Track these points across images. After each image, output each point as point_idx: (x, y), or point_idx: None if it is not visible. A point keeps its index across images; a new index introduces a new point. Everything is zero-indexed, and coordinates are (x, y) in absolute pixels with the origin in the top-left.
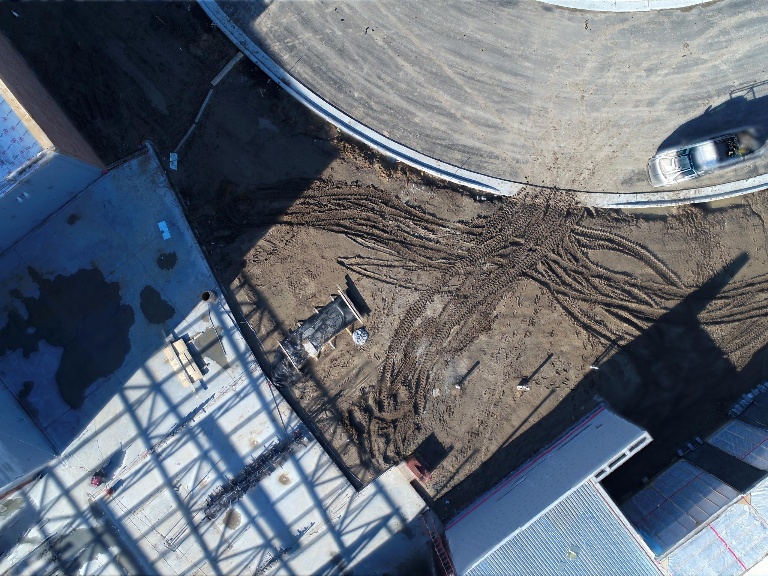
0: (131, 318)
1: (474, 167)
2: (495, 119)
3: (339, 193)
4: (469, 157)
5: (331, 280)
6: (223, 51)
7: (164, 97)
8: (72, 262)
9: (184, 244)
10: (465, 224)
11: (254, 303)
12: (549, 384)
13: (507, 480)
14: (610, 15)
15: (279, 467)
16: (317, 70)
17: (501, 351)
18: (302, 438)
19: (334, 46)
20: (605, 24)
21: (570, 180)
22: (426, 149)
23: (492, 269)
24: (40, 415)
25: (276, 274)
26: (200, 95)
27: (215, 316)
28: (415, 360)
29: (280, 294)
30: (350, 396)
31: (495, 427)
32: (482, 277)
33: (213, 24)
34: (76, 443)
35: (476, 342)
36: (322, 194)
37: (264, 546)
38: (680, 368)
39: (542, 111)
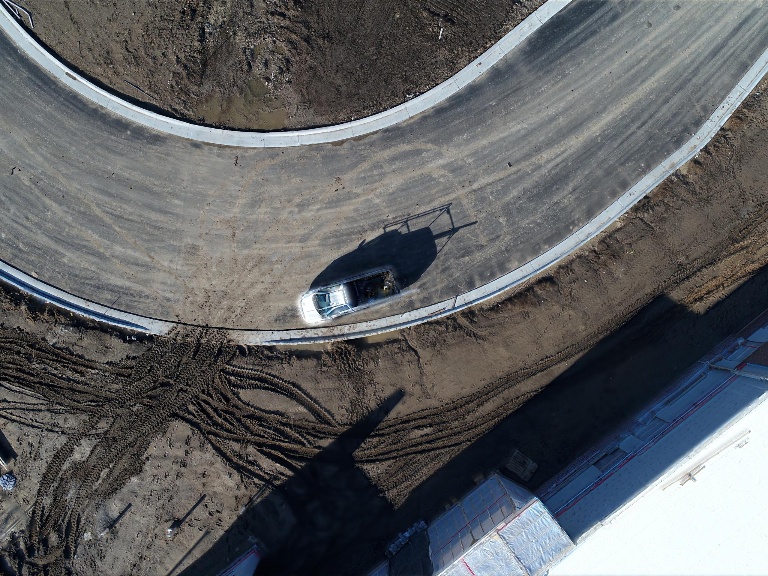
0: None
1: (124, 306)
2: (145, 258)
3: None
4: (119, 296)
5: None
6: None
7: None
8: None
9: None
10: (113, 365)
11: None
12: (202, 526)
13: None
14: (260, 151)
15: None
16: None
17: (153, 493)
18: None
19: None
20: (255, 160)
21: (222, 318)
22: (75, 289)
23: (142, 410)
24: None
25: None
26: None
27: None
28: (65, 504)
29: None
30: None
31: (148, 570)
32: (131, 419)
33: None
34: None
35: (128, 484)
36: None
37: None
38: (336, 507)
39: (193, 249)
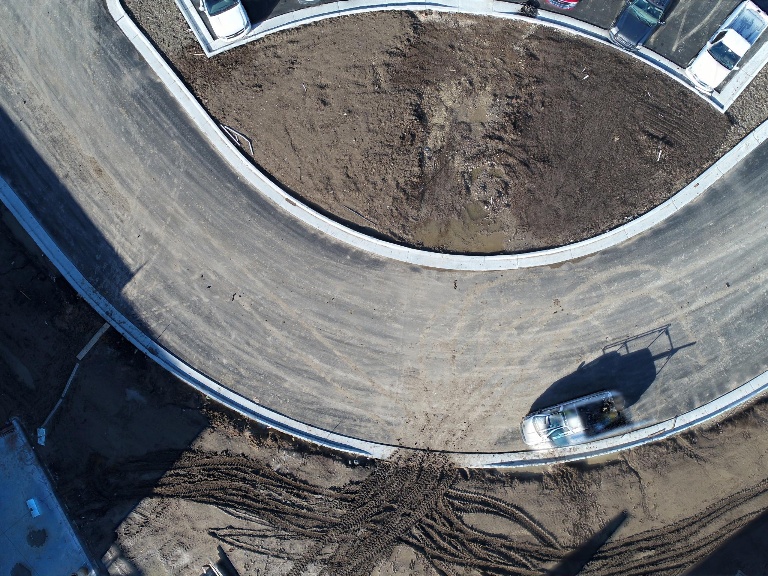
0: None
1: (346, 431)
2: (366, 382)
3: (209, 463)
4: (340, 421)
5: (203, 551)
6: (89, 324)
7: (30, 372)
8: None
9: (53, 521)
10: (337, 491)
11: (126, 575)
12: None
13: None
14: (479, 274)
15: None
16: (185, 338)
17: None
18: None
19: (201, 313)
20: (474, 283)
21: (443, 441)
22: (297, 414)
23: (366, 535)
24: None
25: (148, 546)
26: (66, 369)
27: None
28: None
29: (152, 566)
30: None
31: None
32: (356, 544)
33: (79, 295)
34: None
35: None
36: (192, 464)
37: None
38: None
39: (413, 372)
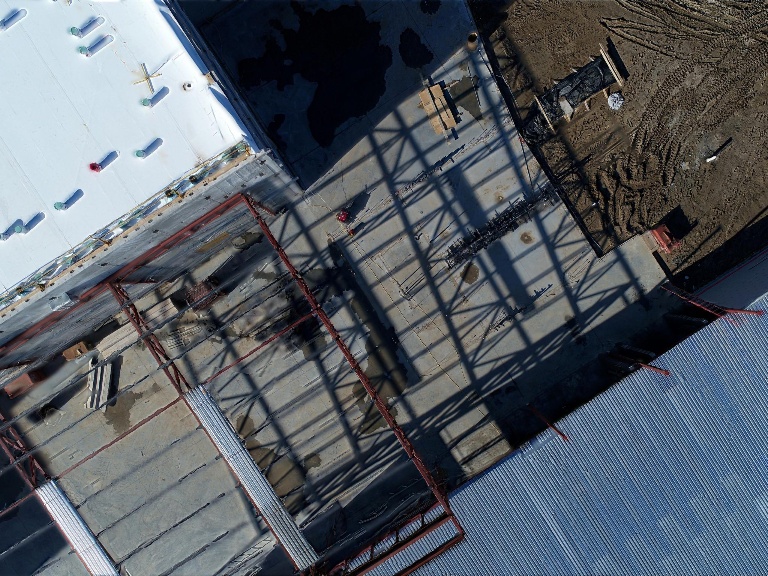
0: (389, 60)
1: None
2: None
3: None
4: None
5: (591, 41)
6: None
7: None
8: None
9: None
10: None
11: (512, 57)
12: None
13: (751, 259)
14: None
15: (522, 225)
16: None
17: (755, 129)
18: None
19: None
20: None
21: None
22: None
23: (754, 45)
24: (288, 150)
25: (537, 30)
26: None
27: (473, 65)
28: (667, 130)
29: (538, 51)
30: (599, 161)
31: (742, 206)
32: (744, 52)
33: None
34: (321, 181)
35: (730, 118)
36: None
37: (499, 304)
38: None
39: None
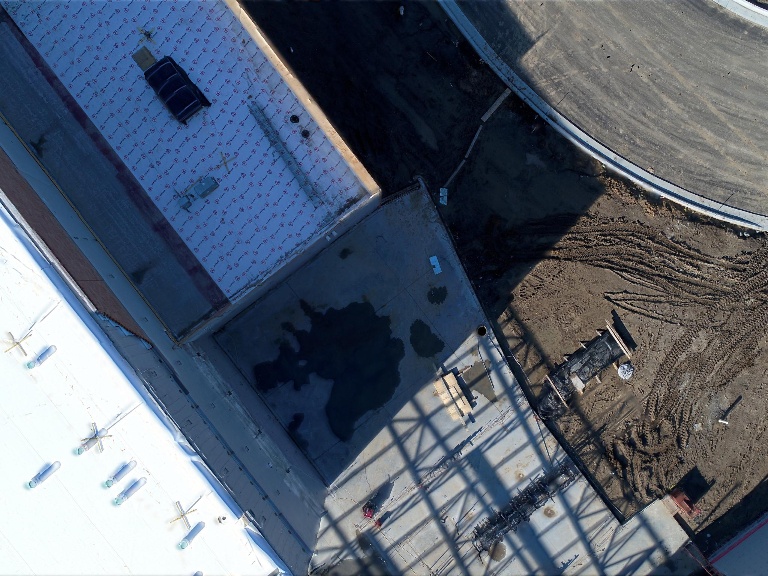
0: (401, 351)
1: (737, 203)
2: (758, 156)
3: (605, 229)
4: (732, 194)
5: (597, 315)
6: (492, 87)
7: (434, 133)
8: (344, 296)
9: (454, 279)
10: (729, 260)
11: (521, 337)
12: None
13: None
14: None
15: None
16: (583, 106)
17: (763, 386)
18: (569, 471)
19: (600, 83)
20: None
21: None
22: (690, 185)
23: (755, 305)
24: (309, 447)
25: (543, 309)
26: (470, 131)
27: (484, 350)
28: (678, 394)
29: (546, 328)
30: (614, 430)
31: (757, 461)
32: (746, 313)
33: (481, 60)
34: (345, 475)
35: (738, 377)
36: (588, 230)
37: None
38: None
39: None
